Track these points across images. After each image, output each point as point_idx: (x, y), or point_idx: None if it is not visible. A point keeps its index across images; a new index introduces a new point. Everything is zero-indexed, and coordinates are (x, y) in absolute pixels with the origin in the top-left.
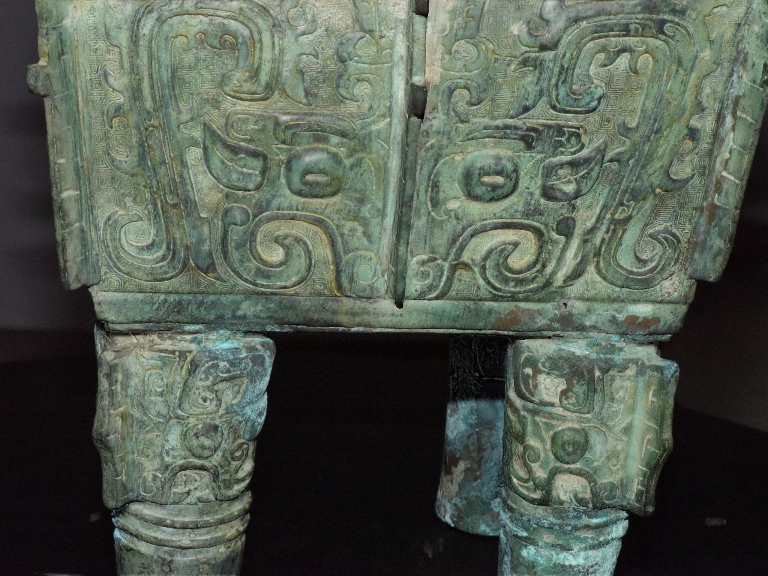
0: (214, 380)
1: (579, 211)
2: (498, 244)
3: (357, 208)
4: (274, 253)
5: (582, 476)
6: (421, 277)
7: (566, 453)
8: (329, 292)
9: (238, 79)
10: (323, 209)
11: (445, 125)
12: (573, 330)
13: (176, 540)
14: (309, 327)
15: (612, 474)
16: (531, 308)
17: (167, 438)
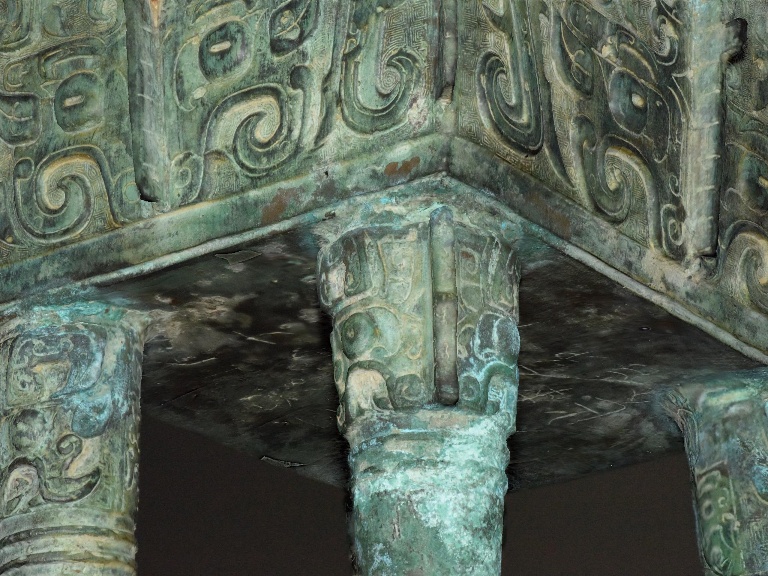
0: (30, 361)
1: (313, 60)
2: (244, 120)
3: (119, 126)
4: (60, 201)
5: (373, 368)
6: (181, 179)
7: (349, 342)
8: (109, 226)
9: (7, 31)
10: (91, 138)
11: (178, 12)
12: (338, 200)
13: (15, 559)
14: (108, 280)
15: (412, 365)
16: (294, 187)
17: (1, 442)
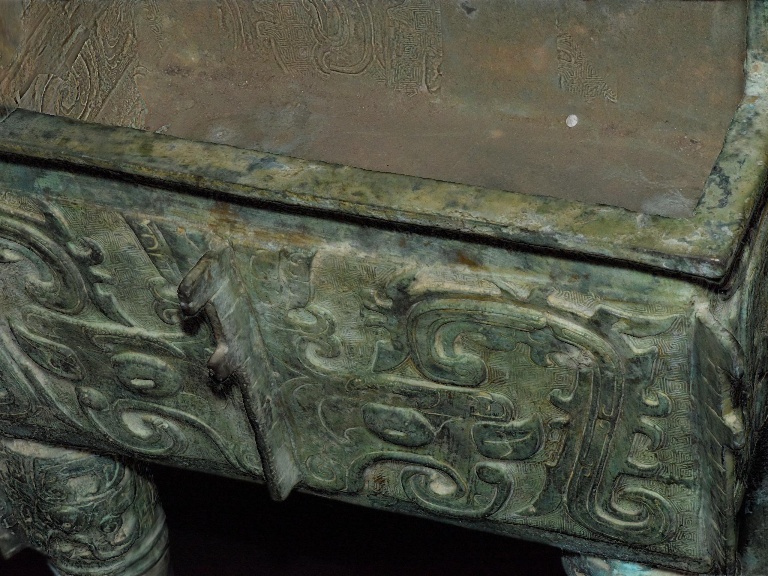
0: None
1: None
2: None
3: None
4: None
5: None
6: None
7: None
8: None
9: None
10: None
11: None
12: None
13: None
14: None
15: None
16: None
17: None
